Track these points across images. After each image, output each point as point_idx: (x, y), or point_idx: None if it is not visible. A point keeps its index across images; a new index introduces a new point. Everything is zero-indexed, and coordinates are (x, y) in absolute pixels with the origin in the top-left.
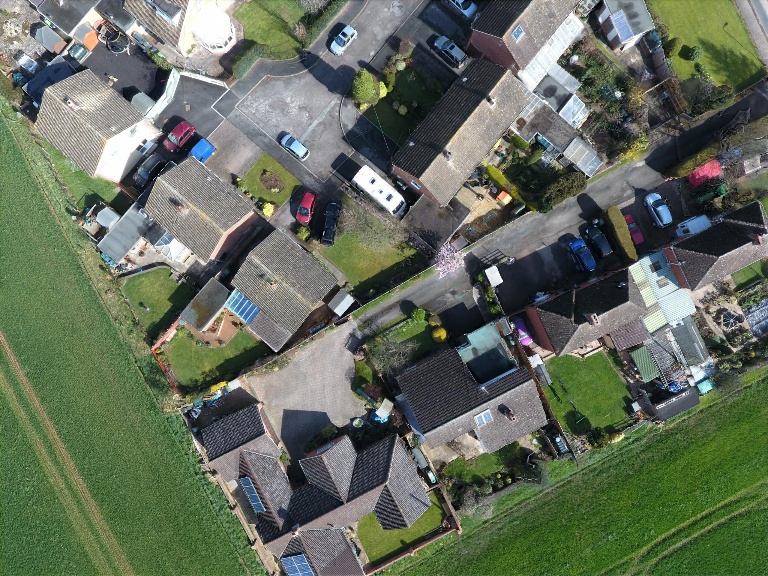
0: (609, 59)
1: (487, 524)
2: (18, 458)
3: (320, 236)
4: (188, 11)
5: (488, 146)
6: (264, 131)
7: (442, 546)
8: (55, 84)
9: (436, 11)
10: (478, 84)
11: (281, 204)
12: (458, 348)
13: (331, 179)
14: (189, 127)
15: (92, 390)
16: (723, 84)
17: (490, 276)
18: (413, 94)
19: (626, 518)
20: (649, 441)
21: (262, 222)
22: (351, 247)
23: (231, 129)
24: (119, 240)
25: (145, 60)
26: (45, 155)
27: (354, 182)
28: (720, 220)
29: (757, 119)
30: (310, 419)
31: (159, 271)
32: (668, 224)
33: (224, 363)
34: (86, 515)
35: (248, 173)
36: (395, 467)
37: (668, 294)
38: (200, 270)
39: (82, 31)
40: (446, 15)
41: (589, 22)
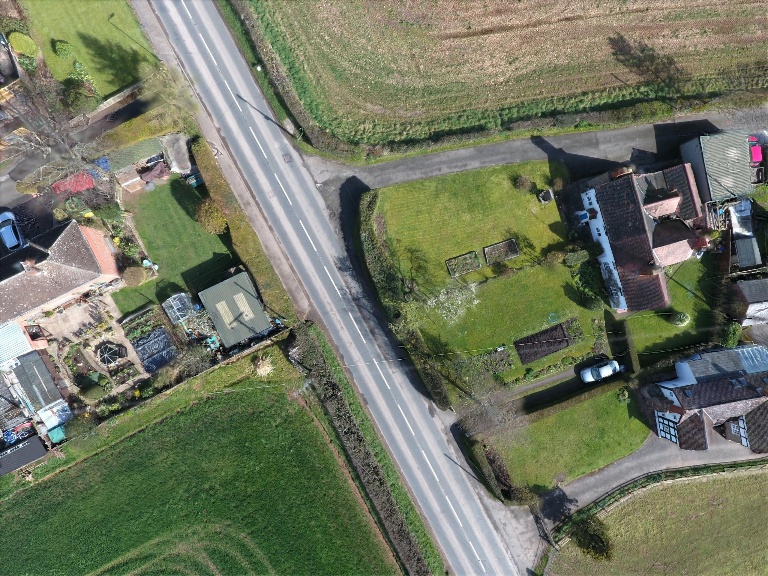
0: None
1: None
2: None
3: None
4: None
5: None
6: None
7: None
8: None
9: None
10: None
11: None
12: None
13: None
14: None
15: None
16: (109, 84)
17: None
18: None
19: None
20: (17, 497)
21: None
22: None
23: None
24: None
25: None
26: None
27: None
28: (28, 244)
29: None
30: None
31: None
32: (16, 248)
33: None
34: None
35: None
36: None
37: None
38: None
39: None
40: None
41: None
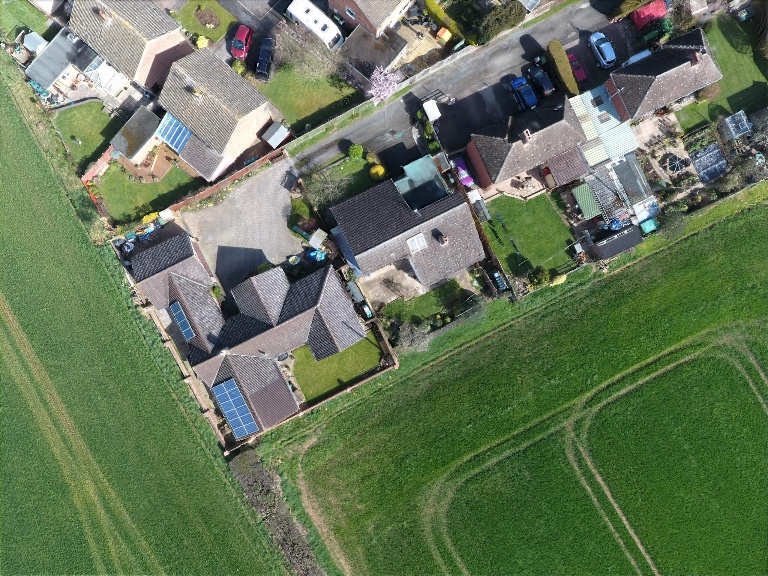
0: None
1: (427, 366)
2: None
3: None
4: None
5: None
6: None
7: (380, 387)
8: None
9: None
10: None
11: (216, 40)
12: (394, 180)
13: (268, 16)
14: None
15: (23, 223)
16: None
17: (428, 110)
18: None
19: (569, 363)
20: (593, 287)
21: None
22: (288, 85)
23: None
24: (47, 66)
25: None
26: None
27: (289, 13)
28: (661, 47)
29: None
30: (245, 256)
31: (91, 104)
32: (611, 62)
33: (158, 198)
34: (17, 347)
35: (183, 8)
36: (327, 294)
37: (610, 129)
38: (133, 105)
39: None
40: None
41: None
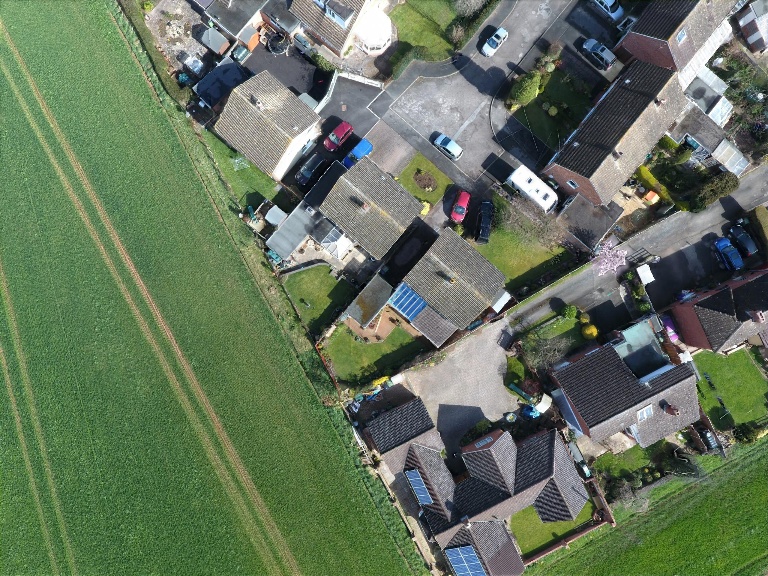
0: (753, 62)
1: (634, 517)
2: (186, 450)
3: (473, 234)
4: (360, 13)
5: (649, 147)
6: (417, 131)
7: (591, 539)
8: (241, 85)
9: (582, 14)
10: (643, 86)
11: (435, 203)
12: (613, 344)
13: (482, 178)
14: (350, 127)
15: (256, 384)
16: None
17: (642, 274)
18: (561, 95)
19: (767, 512)
20: None
21: (417, 220)
22: (502, 245)
23: (386, 129)
24: (287, 237)
25: (303, 61)
26: (208, 154)
27: (510, 181)
28: None
29: None
30: (465, 414)
31: (319, 268)
32: None
33: (382, 358)
34: (251, 507)
35: (403, 172)
36: (558, 461)
37: None
38: (357, 267)
39: (248, 33)
40: (592, 18)
41: None
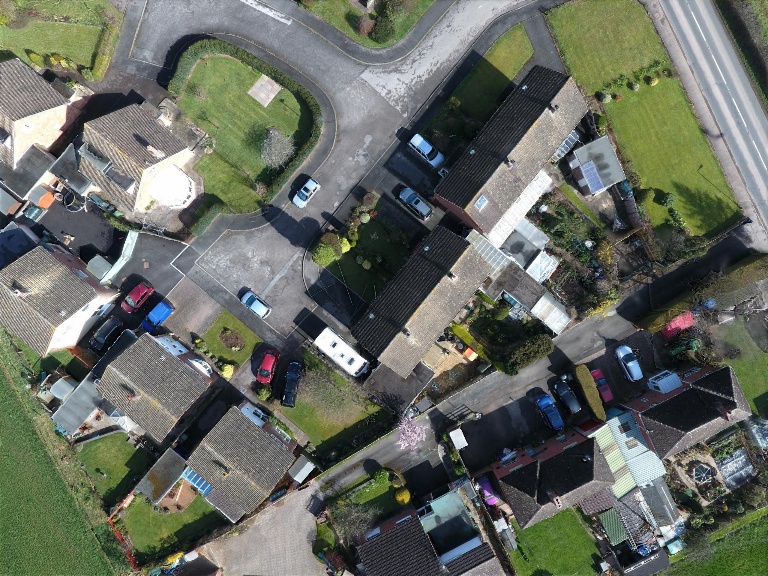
0: (579, 210)
1: None
2: None
3: (281, 396)
4: (142, 183)
5: (450, 316)
6: (225, 287)
7: None
8: (3, 269)
9: (402, 159)
10: (439, 257)
11: (242, 363)
12: (421, 515)
13: (293, 335)
14: (146, 290)
15: (48, 559)
16: (697, 228)
17: (454, 439)
18: (378, 246)
19: None
20: None
21: (222, 382)
22: (313, 405)
23: (191, 286)
24: (74, 411)
25: (103, 216)
26: None
27: (315, 345)
28: (690, 386)
29: (731, 270)
30: None
31: (116, 435)
32: (638, 380)
33: (183, 528)
34: None
35: (208, 331)
36: None
37: (637, 456)
38: None
39: (36, 194)
40: (412, 163)
41: (560, 167)
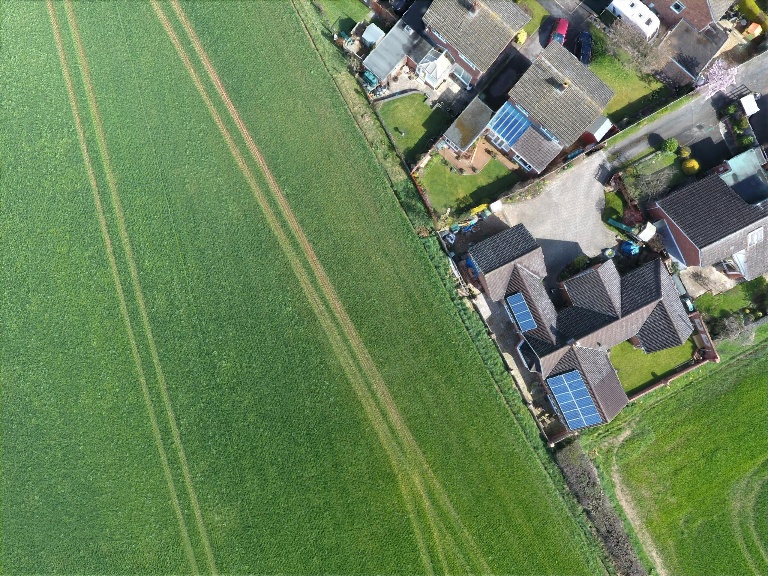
0: None
1: (734, 360)
2: (280, 278)
3: None
4: None
5: None
6: None
7: (691, 380)
8: None
9: None
10: None
11: (531, 33)
12: None
13: (578, 10)
14: None
15: (349, 213)
16: None
17: (746, 105)
18: None
19: None
20: None
21: (513, 51)
22: None
23: None
24: (384, 57)
25: None
26: None
27: (612, 7)
28: None
29: None
30: (562, 249)
31: (413, 96)
32: None
33: (477, 190)
34: (346, 337)
35: None
36: (664, 287)
37: None
38: (452, 98)
39: None
40: None
41: None
